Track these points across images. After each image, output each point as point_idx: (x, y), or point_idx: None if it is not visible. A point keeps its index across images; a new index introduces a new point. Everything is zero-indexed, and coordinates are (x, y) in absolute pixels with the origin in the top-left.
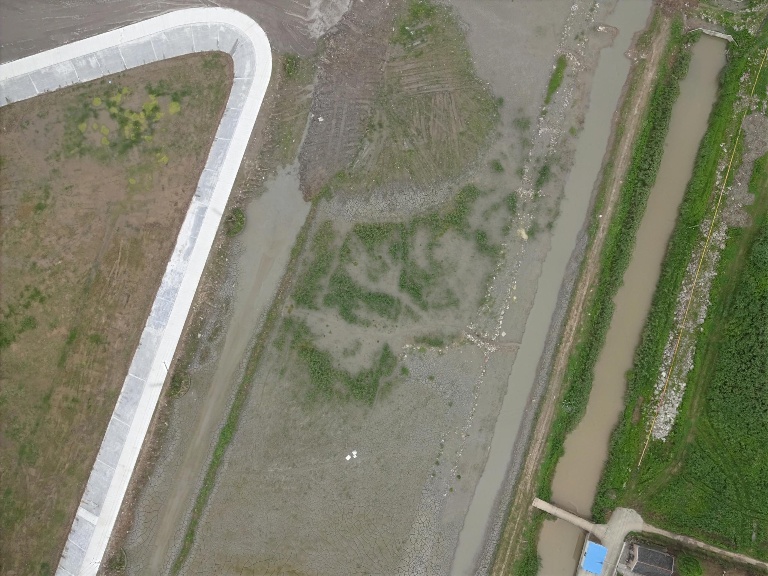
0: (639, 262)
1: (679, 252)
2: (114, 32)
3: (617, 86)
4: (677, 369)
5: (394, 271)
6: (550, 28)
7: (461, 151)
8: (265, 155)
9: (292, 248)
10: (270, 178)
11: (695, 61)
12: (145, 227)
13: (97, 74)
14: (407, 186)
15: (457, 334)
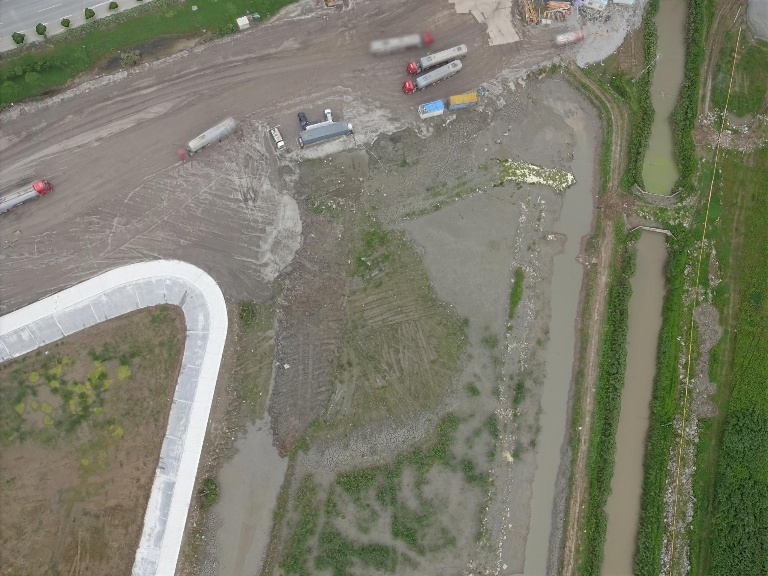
0: (622, 465)
1: (658, 452)
2: (47, 300)
3: (574, 292)
4: (676, 573)
5: (384, 518)
6: (502, 241)
7: (435, 380)
8: (232, 414)
9: (273, 512)
10: (240, 437)
11: (641, 257)
12: (105, 512)
13: (31, 346)
14: (386, 425)
15: (458, 575)
